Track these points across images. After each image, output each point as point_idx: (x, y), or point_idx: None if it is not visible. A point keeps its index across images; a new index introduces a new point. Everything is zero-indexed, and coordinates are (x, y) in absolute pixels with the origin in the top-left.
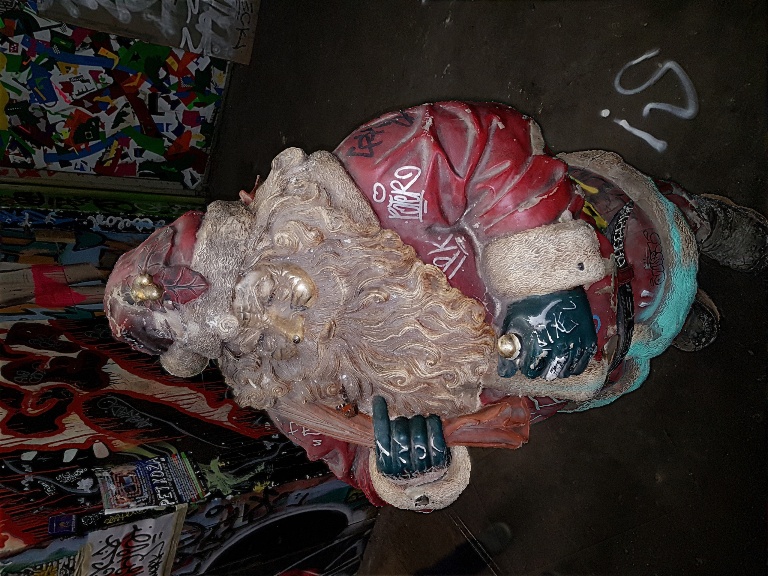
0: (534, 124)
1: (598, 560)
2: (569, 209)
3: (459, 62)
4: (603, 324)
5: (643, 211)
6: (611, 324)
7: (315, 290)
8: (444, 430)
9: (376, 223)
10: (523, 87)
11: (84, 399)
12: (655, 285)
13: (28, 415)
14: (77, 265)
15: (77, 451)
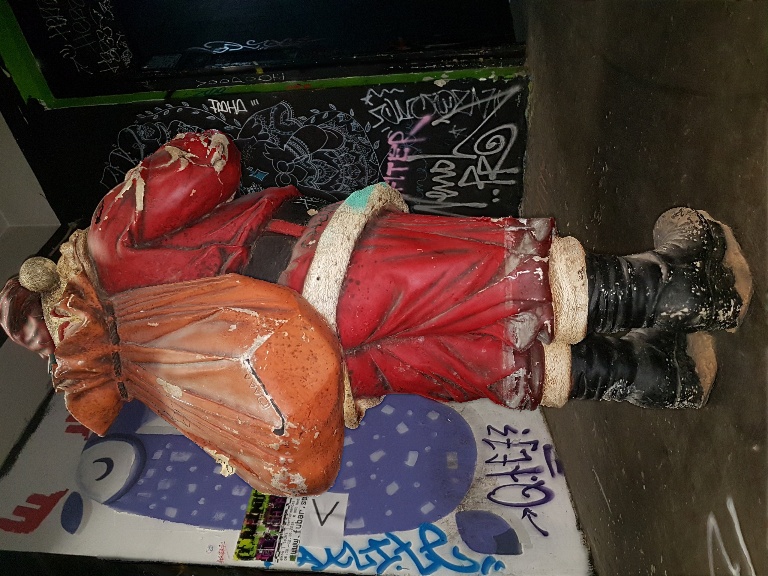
0: None
1: None
2: None
3: None
4: None
5: None
6: None
7: None
8: None
9: None
10: None
11: None
12: None
13: None
14: None
15: None
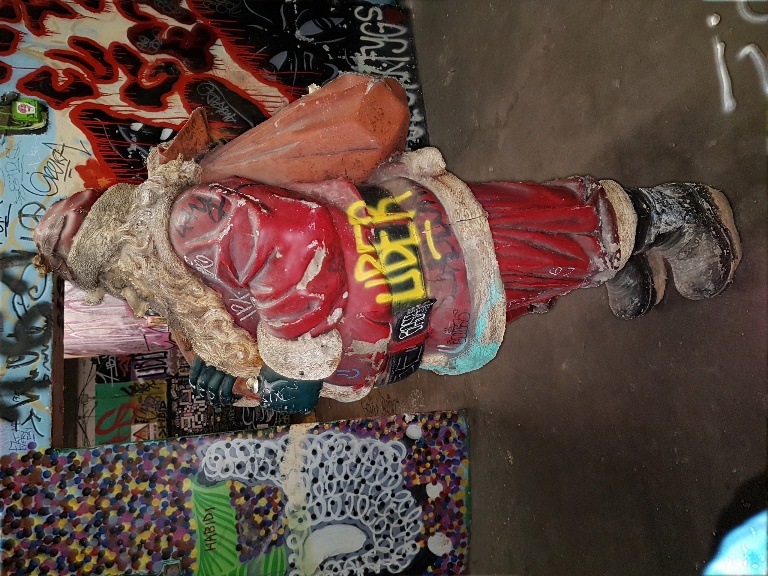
0: (320, 251)
1: (509, 379)
2: (310, 332)
3: None
4: (362, 374)
5: (468, 291)
6: (370, 375)
7: (151, 293)
8: (235, 385)
9: (187, 276)
10: None
11: (188, 80)
12: (454, 344)
13: (141, 86)
14: None
15: (172, 132)
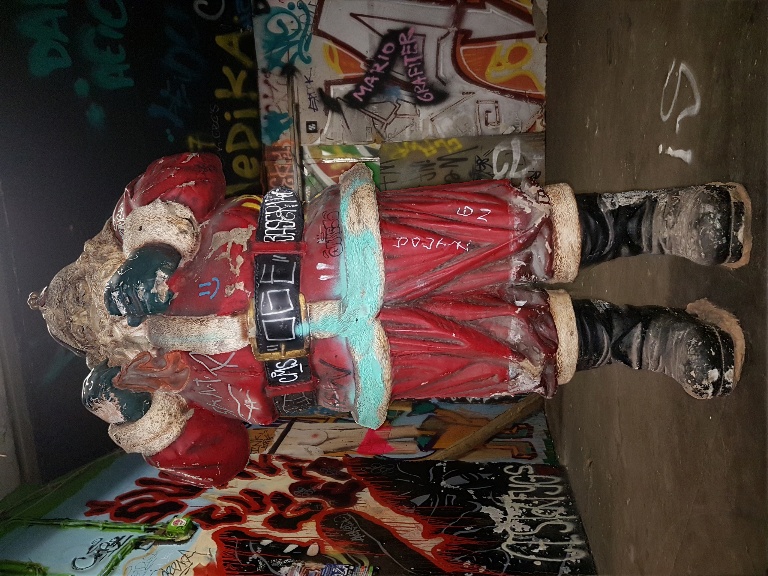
0: None
1: None
2: (160, 196)
3: (603, 164)
4: (222, 284)
5: (339, 197)
6: (230, 284)
7: None
8: None
9: (111, 243)
10: (626, 160)
11: (328, 513)
12: (332, 257)
13: (285, 516)
14: (403, 426)
15: (297, 547)
